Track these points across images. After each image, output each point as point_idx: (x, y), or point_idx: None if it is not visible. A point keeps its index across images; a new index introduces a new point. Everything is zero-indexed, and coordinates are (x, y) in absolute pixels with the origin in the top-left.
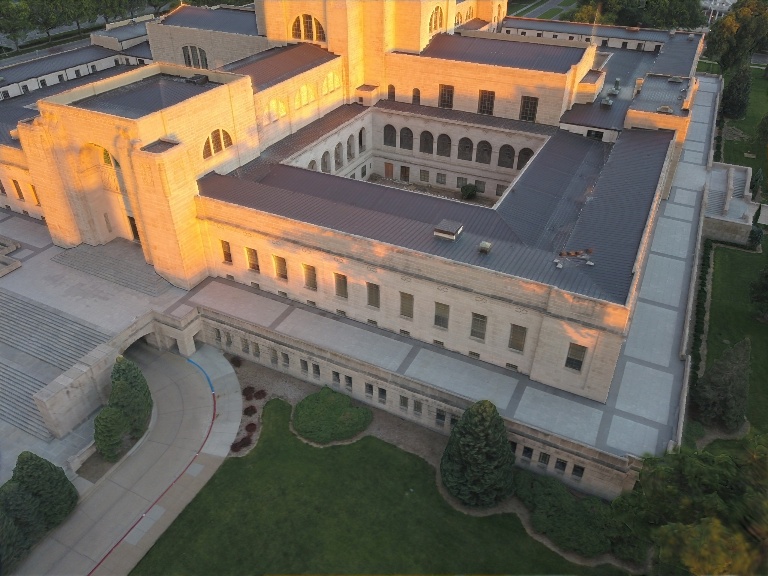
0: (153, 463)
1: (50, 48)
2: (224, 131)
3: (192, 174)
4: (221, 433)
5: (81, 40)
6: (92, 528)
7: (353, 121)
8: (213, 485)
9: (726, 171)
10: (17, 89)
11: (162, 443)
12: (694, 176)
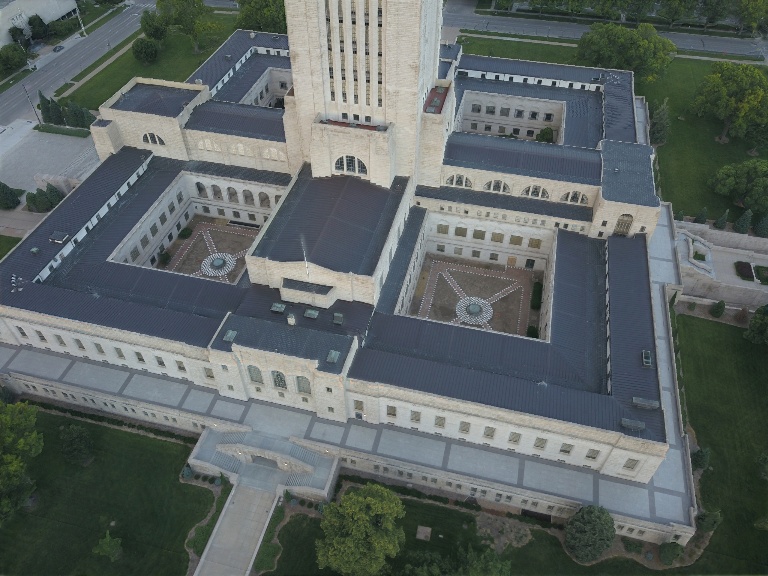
0: (26, 220)
1: (530, 20)
2: (159, 136)
3: (110, 143)
4: None
5: (563, 22)
6: (0, 217)
7: (263, 185)
8: (8, 238)
9: (311, 465)
10: None
11: (37, 219)
12: (275, 424)
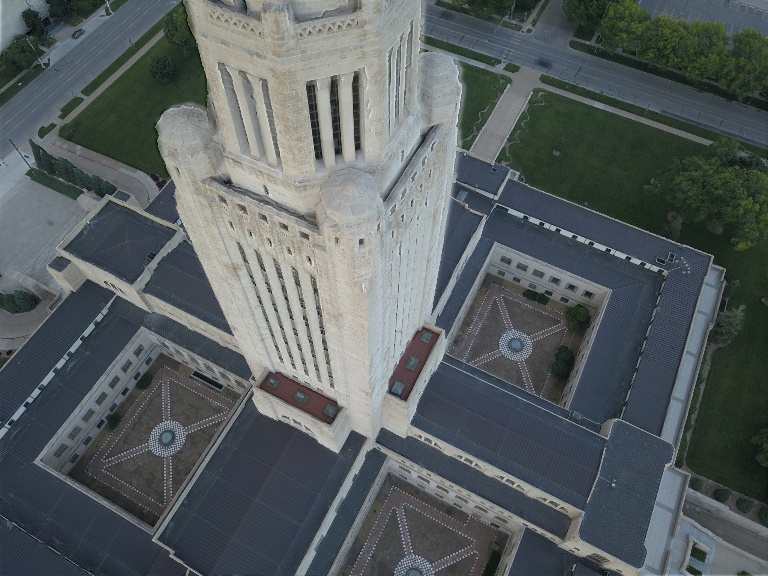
0: None
1: (635, 70)
2: None
3: (68, 284)
4: (1, 343)
5: (676, 83)
6: None
7: (221, 370)
8: None
9: None
10: None
11: (5, 321)
12: None
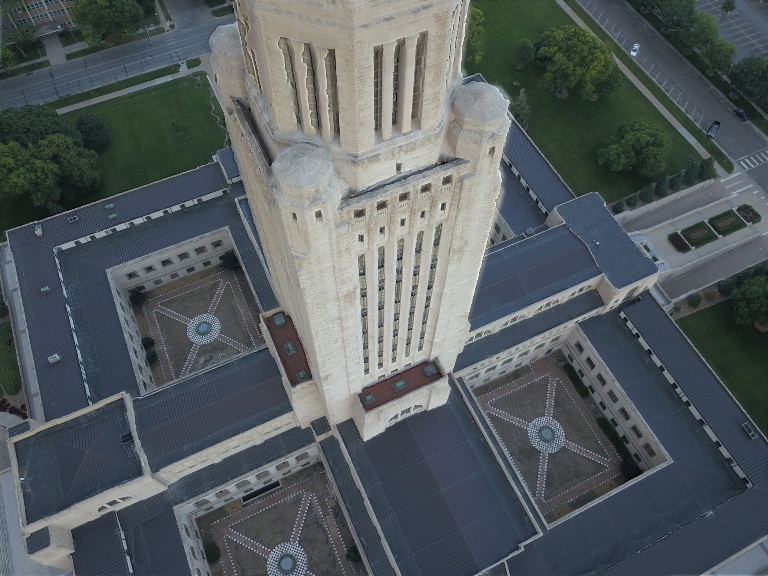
0: None
1: None
2: (121, 497)
3: (64, 550)
4: None
5: None
6: None
7: (282, 460)
8: None
9: None
10: (124, 225)
11: None
12: None
